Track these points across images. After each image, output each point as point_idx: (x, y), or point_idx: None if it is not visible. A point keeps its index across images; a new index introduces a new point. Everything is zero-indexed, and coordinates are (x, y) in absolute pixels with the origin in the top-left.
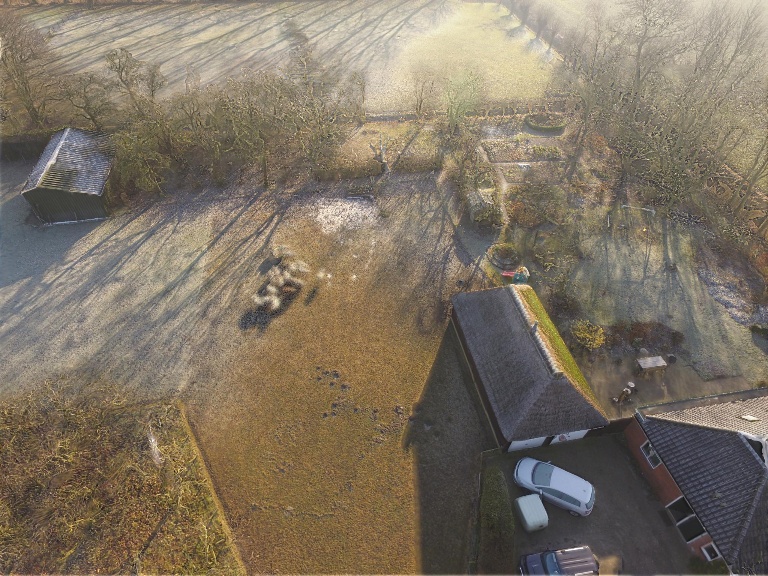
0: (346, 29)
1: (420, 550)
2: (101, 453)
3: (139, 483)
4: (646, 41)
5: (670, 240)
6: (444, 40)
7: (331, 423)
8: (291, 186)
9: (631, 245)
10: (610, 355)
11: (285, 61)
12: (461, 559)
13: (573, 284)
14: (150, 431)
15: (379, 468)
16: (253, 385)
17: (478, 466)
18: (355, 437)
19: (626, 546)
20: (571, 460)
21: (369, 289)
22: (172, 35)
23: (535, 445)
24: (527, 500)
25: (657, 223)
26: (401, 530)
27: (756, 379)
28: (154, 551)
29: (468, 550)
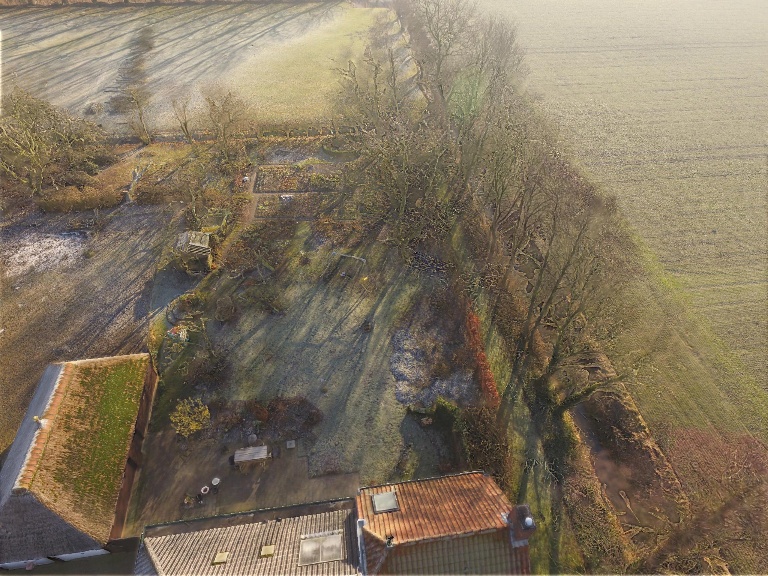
0: (202, 37)
1: None
2: None
3: None
4: (443, 59)
5: (390, 292)
6: (298, 50)
7: None
8: (10, 218)
9: (341, 297)
10: (221, 440)
11: (110, 72)
12: None
13: (195, 354)
14: None
15: None
16: None
17: None
18: None
19: None
20: None
21: (5, 347)
22: (12, 42)
23: (46, 561)
24: None
25: (390, 270)
26: None
27: (372, 477)
28: None
29: None
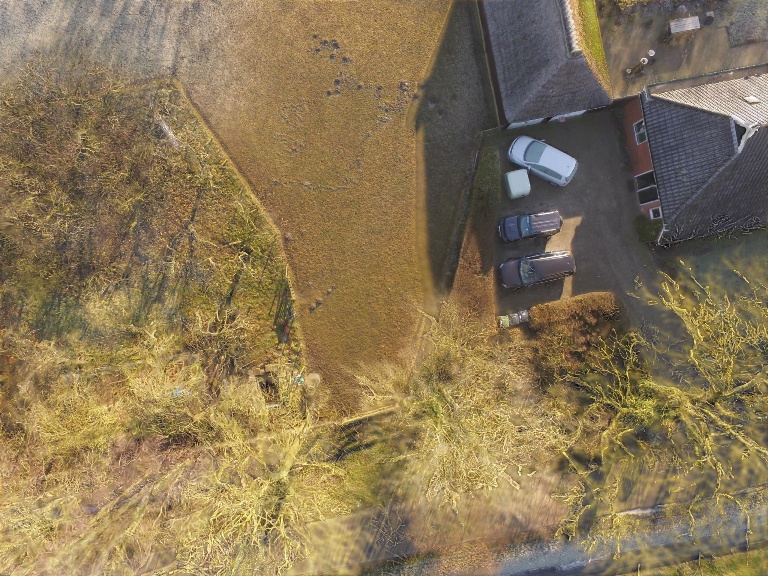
0: None
1: (419, 214)
2: (119, 137)
3: (166, 164)
4: None
5: None
6: None
7: (336, 102)
8: None
9: None
10: (642, 14)
11: None
12: (452, 220)
13: None
14: (161, 119)
15: (384, 147)
16: (248, 59)
17: (477, 143)
18: (360, 116)
19: (589, 208)
20: (564, 136)
21: None
22: None
23: (534, 122)
24: (516, 175)
25: None
26: (404, 199)
27: None
28: (201, 219)
29: (459, 213)
